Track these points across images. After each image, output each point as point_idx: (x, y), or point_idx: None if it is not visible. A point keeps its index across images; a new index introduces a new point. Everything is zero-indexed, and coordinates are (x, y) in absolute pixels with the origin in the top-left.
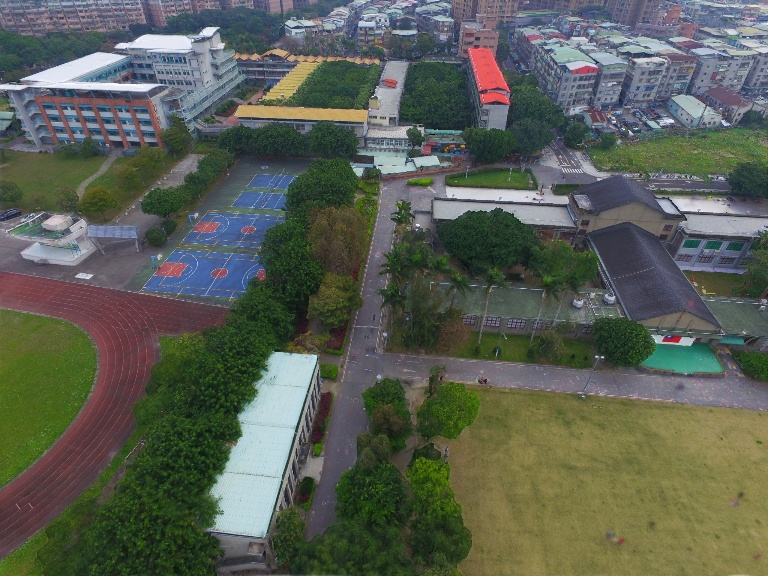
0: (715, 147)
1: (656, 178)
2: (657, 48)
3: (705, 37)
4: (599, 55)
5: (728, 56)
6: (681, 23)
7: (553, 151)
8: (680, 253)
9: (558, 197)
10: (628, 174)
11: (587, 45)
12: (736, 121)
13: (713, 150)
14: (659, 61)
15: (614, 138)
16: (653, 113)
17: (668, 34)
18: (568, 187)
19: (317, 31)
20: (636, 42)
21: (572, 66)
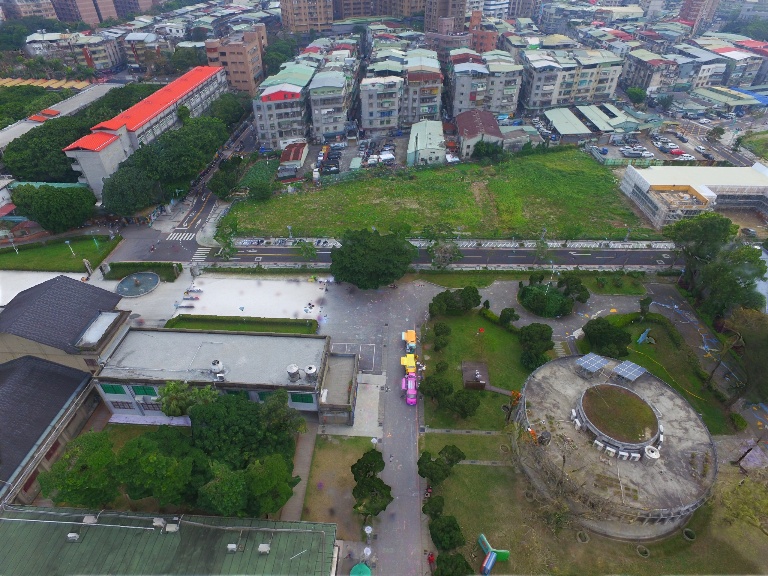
0: (407, 193)
1: (278, 246)
2: (413, 64)
3: (509, 47)
4: (323, 75)
5: (486, 73)
6: (483, 31)
7: (194, 205)
8: (110, 400)
9: (103, 284)
10: (247, 240)
11: (345, 60)
12: (468, 155)
13: (401, 198)
14: (388, 81)
15: (266, 187)
16: (384, 144)
17: (456, 45)
18: (130, 267)
19: (41, 47)
20: (404, 56)
21: (267, 91)
